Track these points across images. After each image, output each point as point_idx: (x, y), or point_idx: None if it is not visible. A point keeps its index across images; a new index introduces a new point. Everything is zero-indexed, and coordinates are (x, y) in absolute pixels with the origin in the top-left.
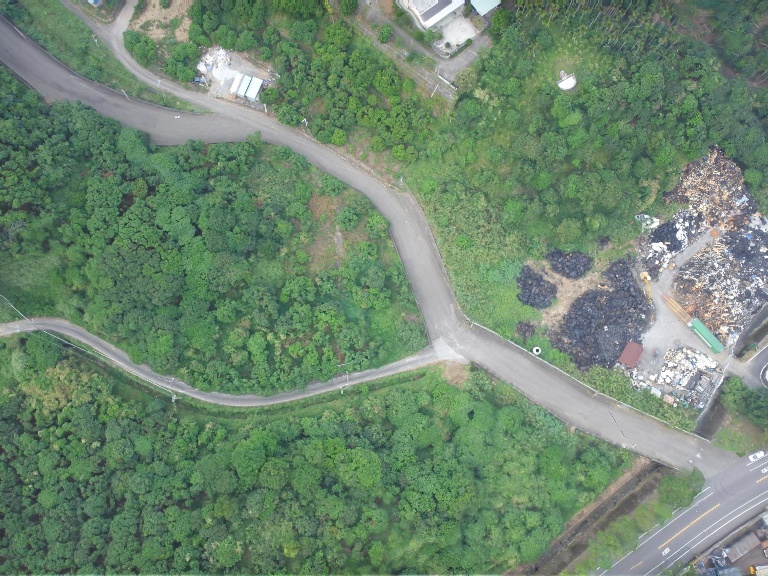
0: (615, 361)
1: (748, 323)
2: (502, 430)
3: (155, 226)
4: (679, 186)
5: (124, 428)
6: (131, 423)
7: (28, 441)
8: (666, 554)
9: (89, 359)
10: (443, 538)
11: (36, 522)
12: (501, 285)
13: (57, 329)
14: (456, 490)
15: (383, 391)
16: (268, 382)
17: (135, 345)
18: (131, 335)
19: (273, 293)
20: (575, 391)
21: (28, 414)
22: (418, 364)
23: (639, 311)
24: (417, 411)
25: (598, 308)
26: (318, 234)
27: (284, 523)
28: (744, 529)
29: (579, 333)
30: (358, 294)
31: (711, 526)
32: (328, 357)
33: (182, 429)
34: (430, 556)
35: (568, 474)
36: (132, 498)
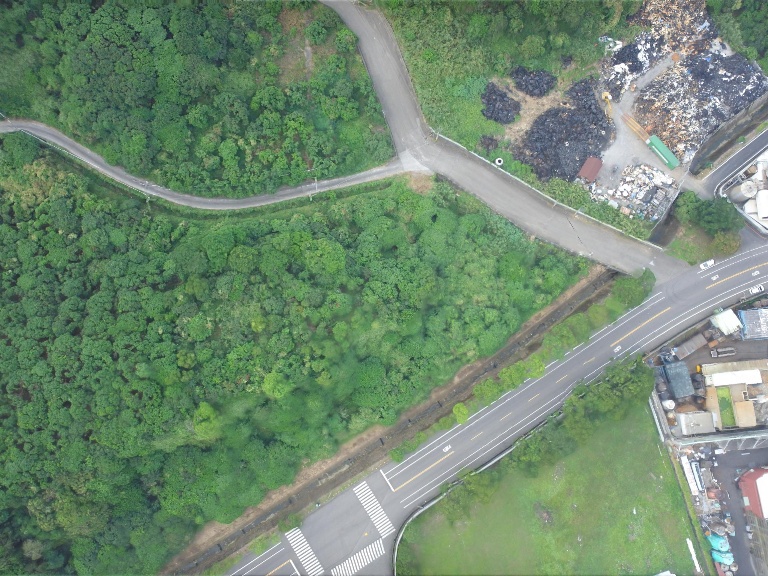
0: (575, 176)
1: (704, 142)
2: (464, 233)
3: (127, 26)
4: (642, 10)
5: (99, 220)
6: (106, 216)
7: (7, 230)
8: (617, 351)
9: (65, 161)
10: (404, 324)
11: (16, 301)
12: (466, 100)
13: (33, 131)
14: (418, 282)
15: (350, 198)
16: (238, 182)
17: (109, 146)
18: (105, 136)
19: (243, 100)
20: (536, 202)
21: (6, 206)
22: (385, 174)
23: (599, 127)
24: (382, 215)
25: (559, 123)
26: (288, 48)
27: (252, 304)
28: (692, 330)
29: (540, 145)
30: (326, 103)
31: (661, 327)
32: (297, 162)
33: (156, 225)
34: (393, 347)
35: (526, 277)
36: (107, 281)
